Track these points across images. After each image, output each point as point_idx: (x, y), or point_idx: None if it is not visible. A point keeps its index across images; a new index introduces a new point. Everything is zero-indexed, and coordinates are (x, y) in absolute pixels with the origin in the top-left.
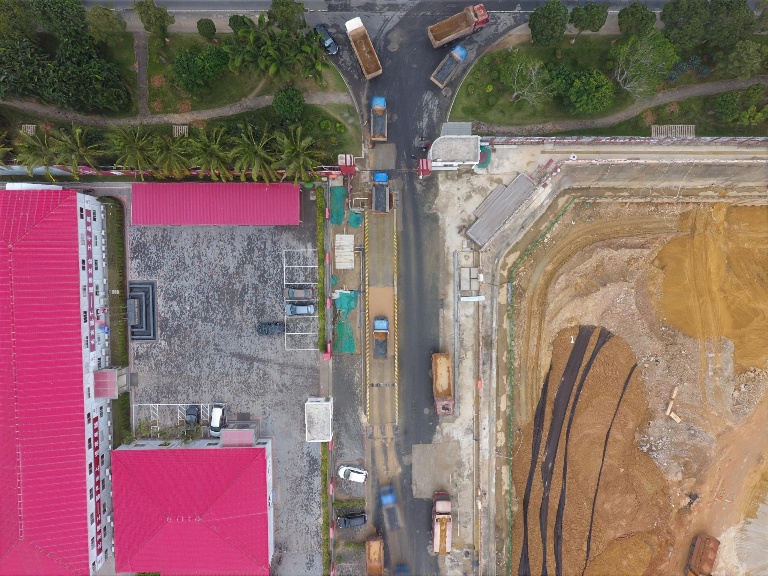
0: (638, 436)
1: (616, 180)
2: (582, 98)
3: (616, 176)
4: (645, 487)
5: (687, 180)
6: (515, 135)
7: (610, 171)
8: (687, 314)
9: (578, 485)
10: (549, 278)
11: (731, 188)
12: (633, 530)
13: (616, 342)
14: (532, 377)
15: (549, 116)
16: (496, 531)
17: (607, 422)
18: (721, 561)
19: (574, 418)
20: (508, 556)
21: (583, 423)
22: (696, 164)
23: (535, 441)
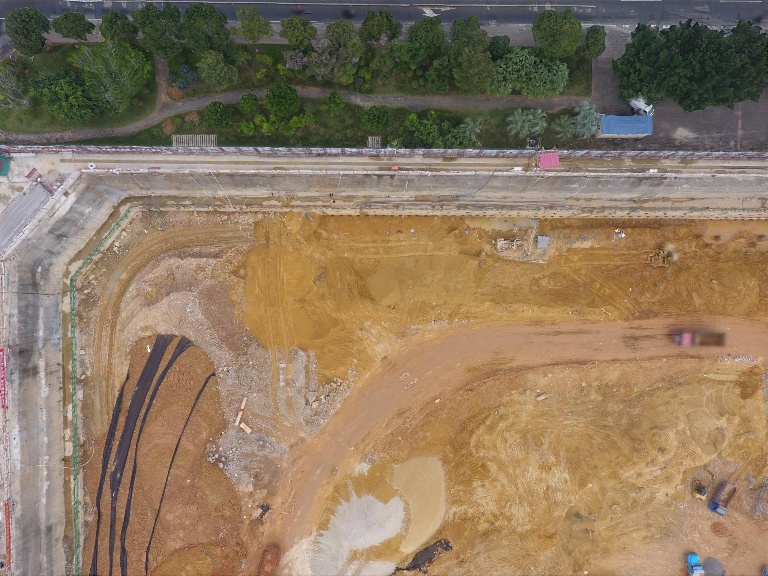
0: (208, 447)
1: (163, 189)
2: (53, 107)
3: (154, 185)
4: (209, 498)
5: (235, 189)
6: (34, 143)
7: (139, 180)
8: (260, 324)
9: (144, 495)
10: (126, 287)
11: (293, 198)
12: (193, 541)
13: (194, 352)
14: (106, 386)
15: (68, 124)
16: (64, 541)
17: (177, 432)
18: (294, 573)
19: (144, 428)
20: (78, 566)
21: (153, 433)
22: (218, 174)
23: (106, 451)
